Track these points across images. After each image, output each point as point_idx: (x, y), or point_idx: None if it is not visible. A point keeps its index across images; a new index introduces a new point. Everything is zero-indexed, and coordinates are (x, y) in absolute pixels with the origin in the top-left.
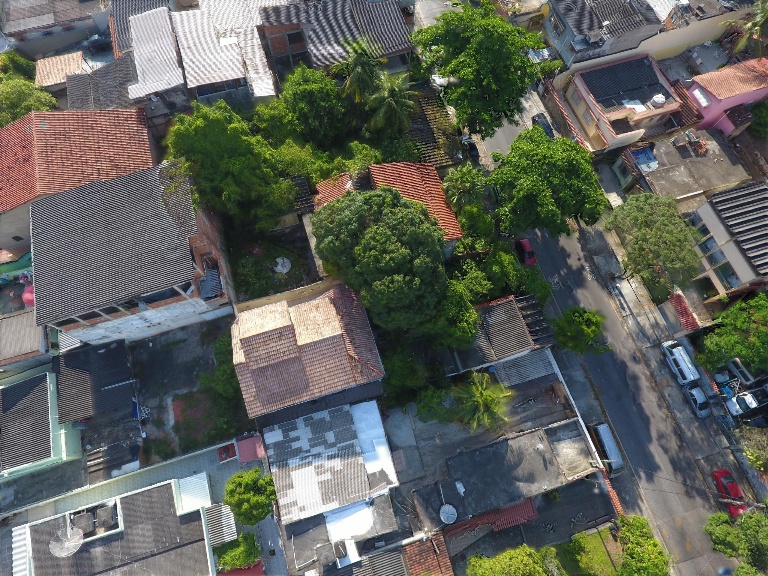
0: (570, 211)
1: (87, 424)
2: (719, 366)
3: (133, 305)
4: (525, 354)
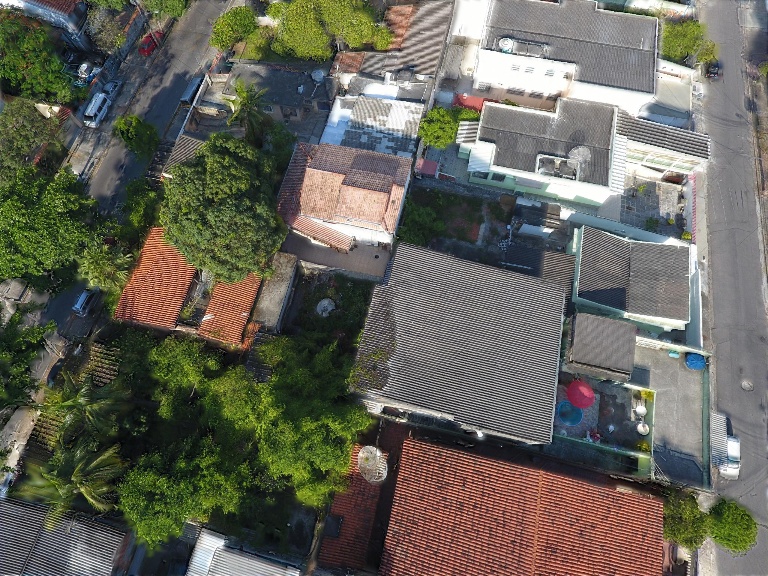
0: None
1: None
2: None
3: None
4: None
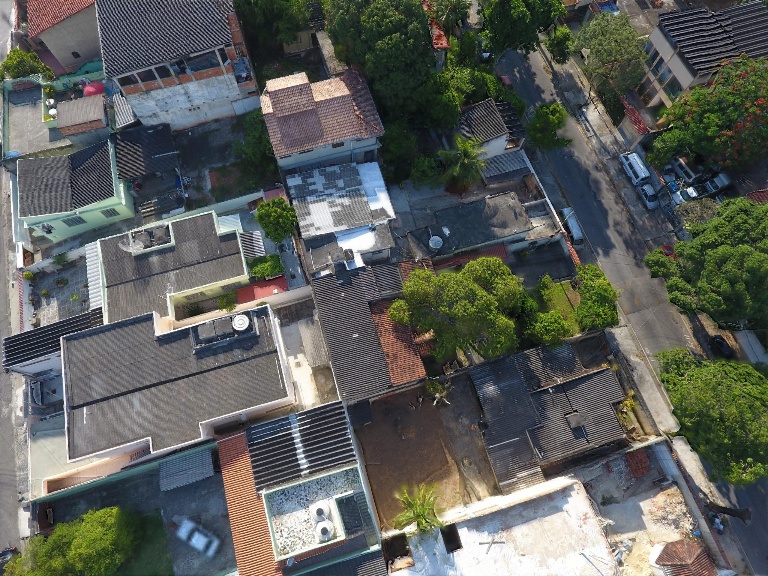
0: (539, 21)
1: (138, 193)
2: (667, 168)
3: (182, 70)
4: (503, 153)
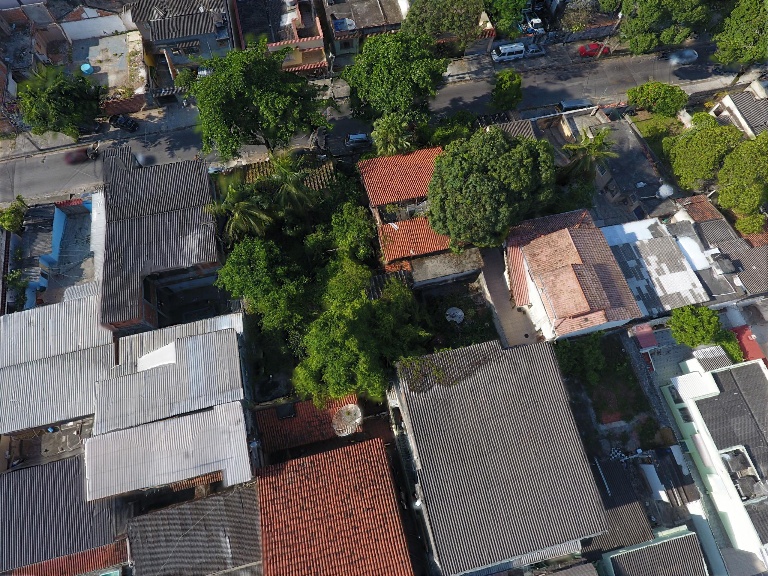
0: None
1: None
2: None
3: None
4: None
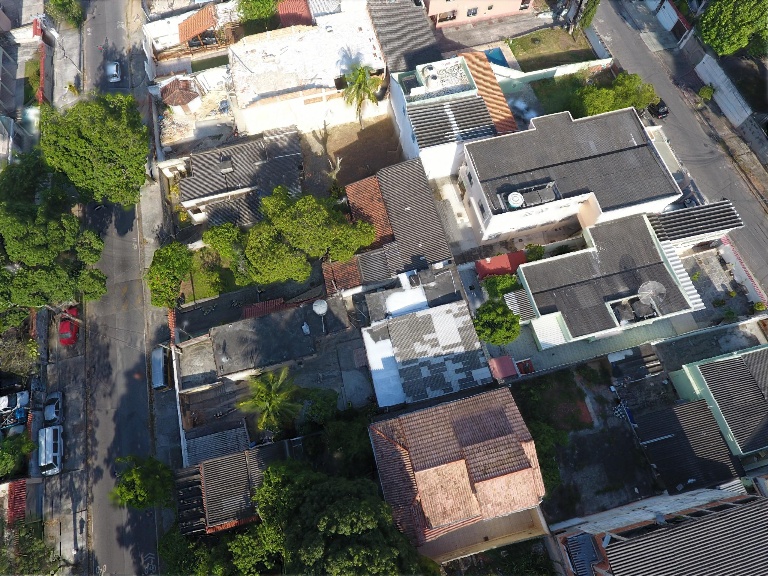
0: None
1: None
2: None
3: (673, 522)
4: None
